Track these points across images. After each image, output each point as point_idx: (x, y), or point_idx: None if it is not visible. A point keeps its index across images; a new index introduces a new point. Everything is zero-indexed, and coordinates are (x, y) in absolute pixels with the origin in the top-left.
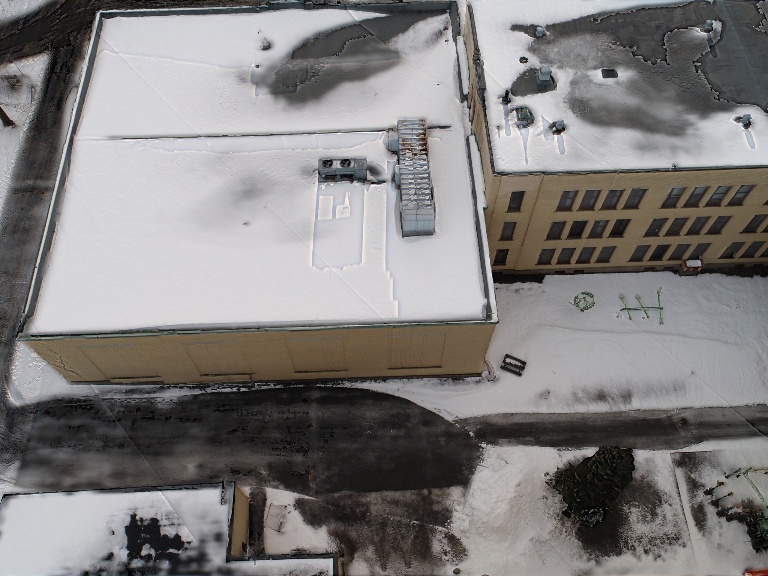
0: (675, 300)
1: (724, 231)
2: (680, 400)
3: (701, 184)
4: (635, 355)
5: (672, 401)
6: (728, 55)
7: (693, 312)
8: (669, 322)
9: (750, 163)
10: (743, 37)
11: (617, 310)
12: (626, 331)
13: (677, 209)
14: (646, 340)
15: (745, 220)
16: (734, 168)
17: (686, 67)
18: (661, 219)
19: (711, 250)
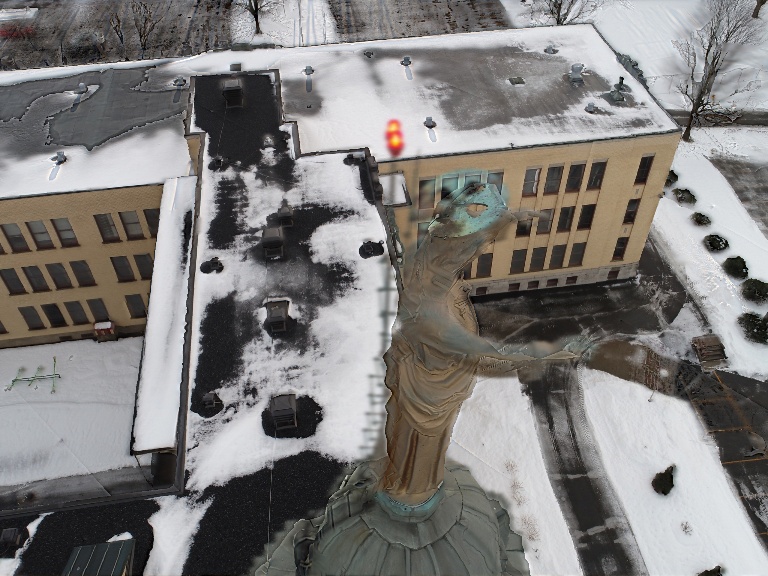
0: (81, 367)
1: (98, 281)
2: (35, 472)
3: (2, 221)
4: (2, 428)
5: (25, 474)
6: (86, 109)
7: (93, 377)
8: (63, 390)
9: (36, 192)
10: (112, 95)
11: (9, 383)
12: (6, 404)
13: (10, 255)
14: (23, 410)
15: (106, 265)
16: (16, 198)
17: (36, 121)
18: (7, 270)
19: (111, 308)
